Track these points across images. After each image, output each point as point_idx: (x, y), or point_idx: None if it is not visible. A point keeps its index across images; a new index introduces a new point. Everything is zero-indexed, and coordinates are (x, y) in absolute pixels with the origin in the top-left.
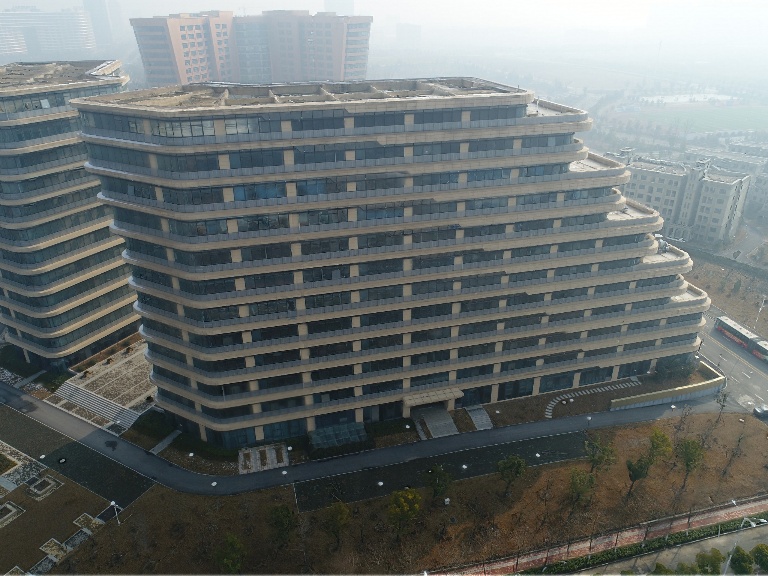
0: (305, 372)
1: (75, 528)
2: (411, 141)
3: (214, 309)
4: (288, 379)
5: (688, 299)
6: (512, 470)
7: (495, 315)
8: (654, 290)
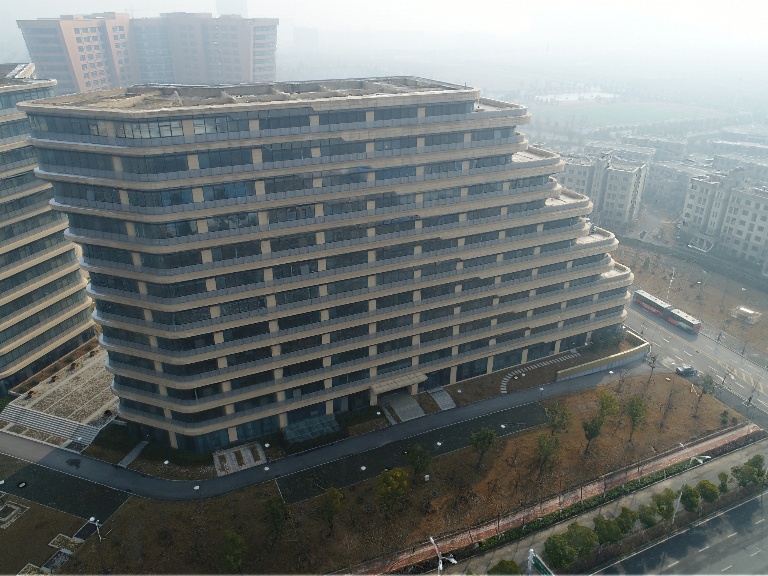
0: (277, 368)
1: (52, 550)
2: (373, 137)
3: (185, 311)
4: (260, 377)
5: (615, 275)
6: (485, 441)
7: (452, 300)
8: (587, 268)
